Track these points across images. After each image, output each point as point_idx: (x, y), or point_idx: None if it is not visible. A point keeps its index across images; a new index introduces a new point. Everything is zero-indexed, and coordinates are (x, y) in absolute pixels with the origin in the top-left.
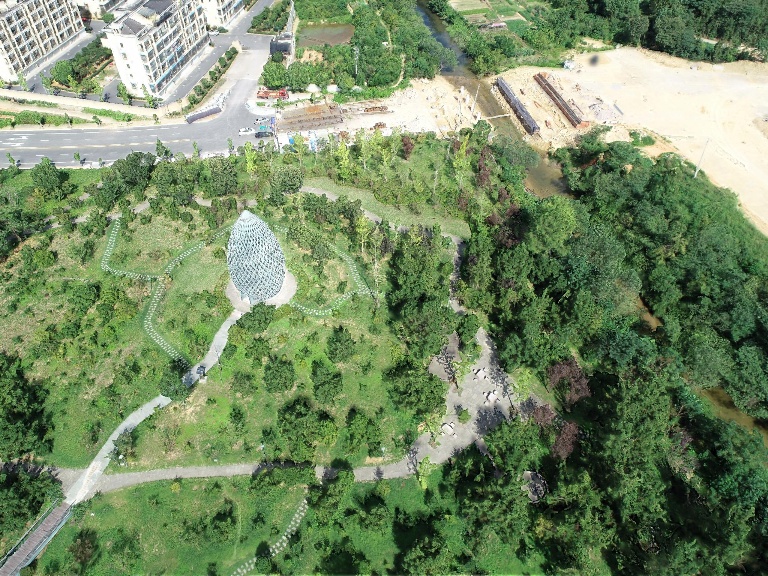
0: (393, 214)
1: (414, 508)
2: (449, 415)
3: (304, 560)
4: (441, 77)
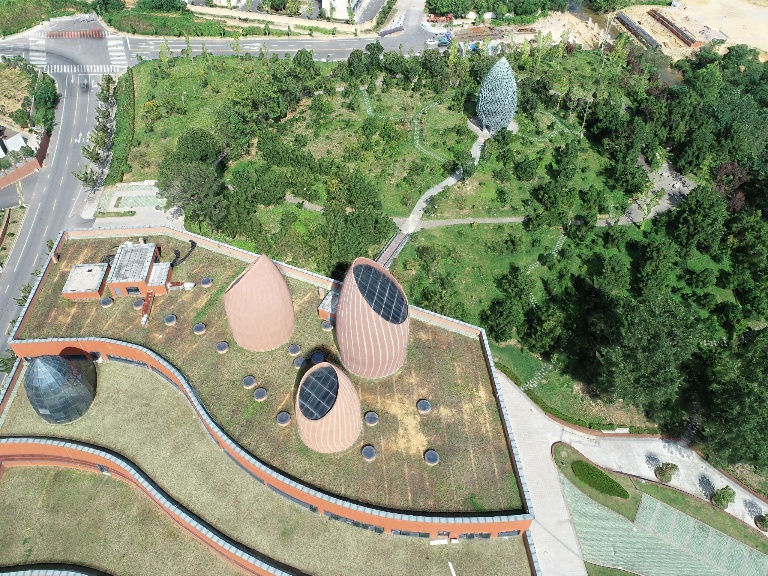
0: None
1: (637, 240)
2: (648, 195)
3: (572, 262)
4: (568, 13)
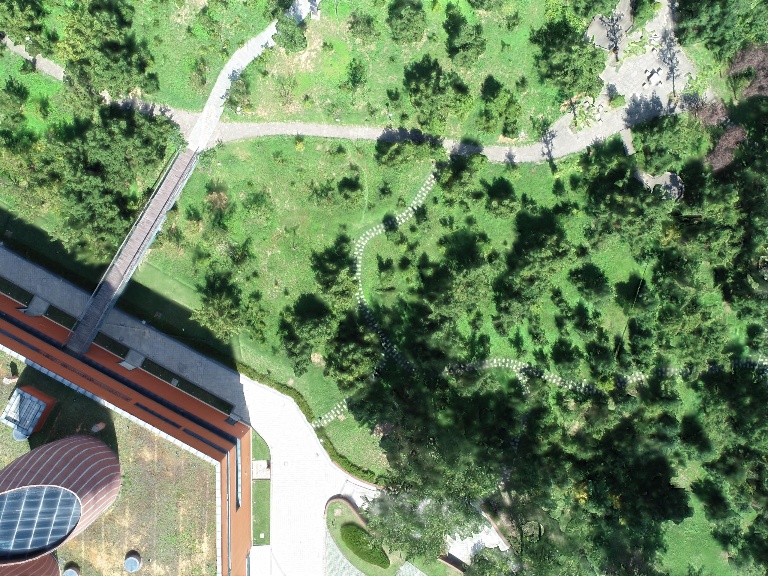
0: None
1: (541, 196)
2: (599, 95)
3: (429, 232)
4: None
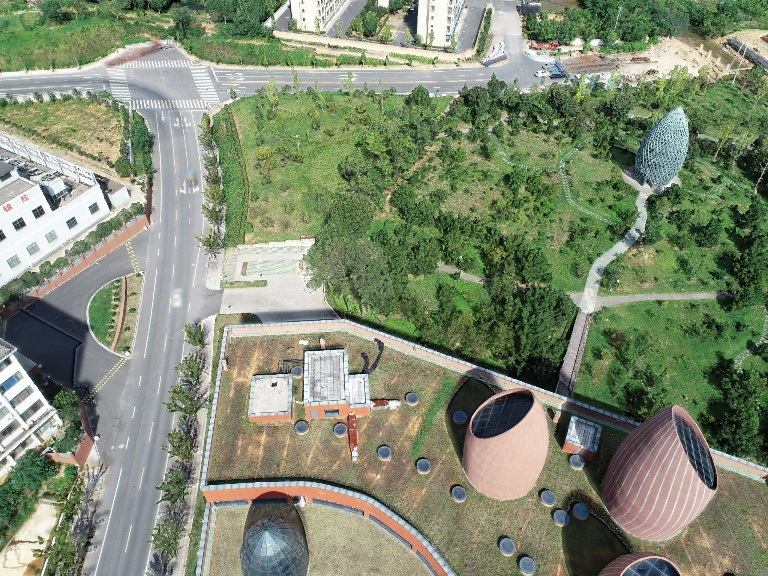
0: (717, 133)
1: None
2: None
3: None
4: (674, 38)
